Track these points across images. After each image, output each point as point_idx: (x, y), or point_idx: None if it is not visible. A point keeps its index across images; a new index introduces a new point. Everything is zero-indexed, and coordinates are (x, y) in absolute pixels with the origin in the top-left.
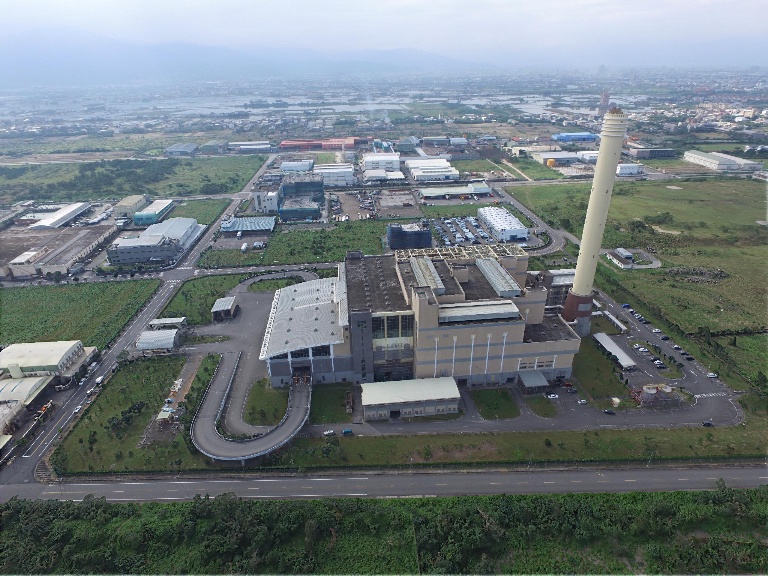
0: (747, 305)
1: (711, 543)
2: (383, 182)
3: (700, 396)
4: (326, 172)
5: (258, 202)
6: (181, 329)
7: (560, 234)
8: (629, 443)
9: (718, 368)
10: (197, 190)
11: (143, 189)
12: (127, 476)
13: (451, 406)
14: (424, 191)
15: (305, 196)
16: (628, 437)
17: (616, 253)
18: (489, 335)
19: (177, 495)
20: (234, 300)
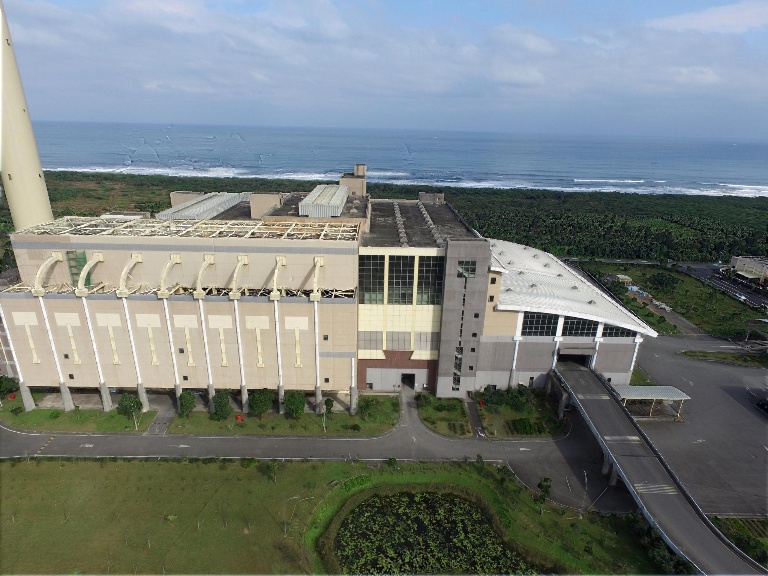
0: None
1: None
2: None
3: None
4: None
5: None
6: None
7: None
8: None
9: None
10: None
11: None
12: None
13: None
14: None
15: None
16: None
17: None
18: None
19: None
20: None
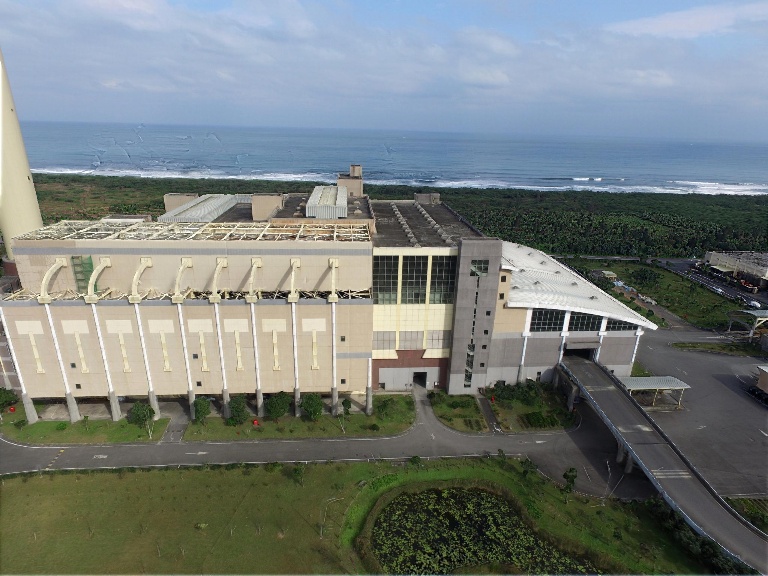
0: None
1: None
2: None
3: None
4: None
5: None
6: None
7: None
8: None
9: None
10: None
11: None
12: None
13: None
14: None
15: None
16: None
17: None
18: None
19: None
20: None
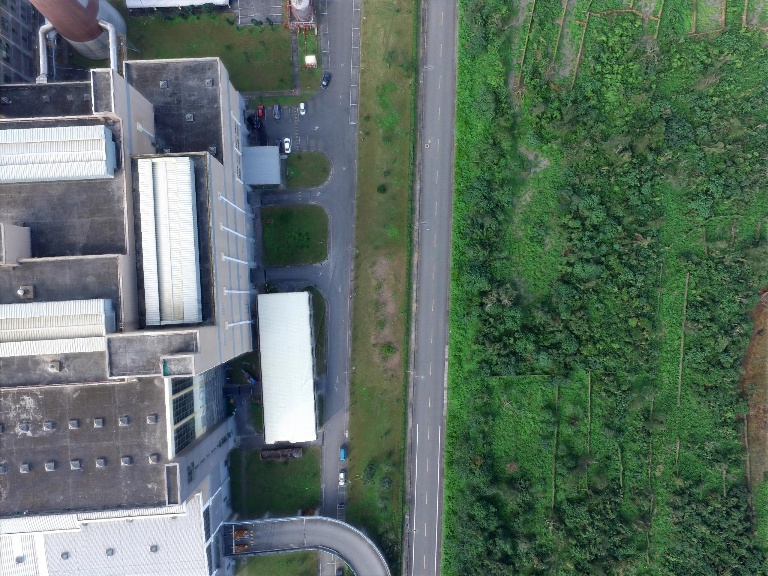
0: None
1: None
2: None
3: None
4: None
5: None
6: None
7: None
8: (386, 85)
9: None
10: None
11: None
12: None
13: None
14: None
15: None
16: (375, 80)
17: None
18: (221, 227)
19: None
20: None
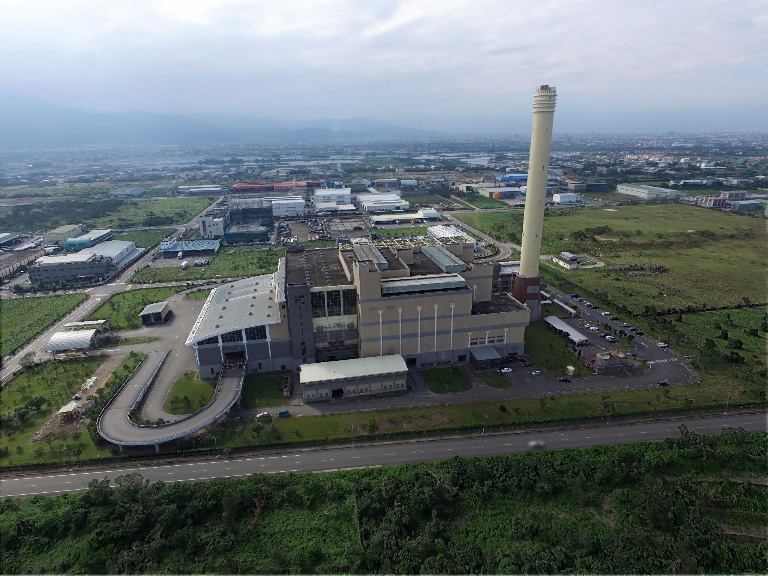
0: (688, 291)
1: (680, 483)
2: (334, 212)
3: (653, 362)
4: (276, 203)
5: (203, 228)
6: (102, 332)
7: (507, 246)
8: (587, 404)
9: (667, 339)
10: (140, 223)
11: (81, 223)
12: (10, 472)
13: (399, 382)
14: (374, 217)
15: (253, 222)
16: (585, 399)
17: (561, 256)
18: (436, 306)
19: (71, 487)
20: (166, 304)
